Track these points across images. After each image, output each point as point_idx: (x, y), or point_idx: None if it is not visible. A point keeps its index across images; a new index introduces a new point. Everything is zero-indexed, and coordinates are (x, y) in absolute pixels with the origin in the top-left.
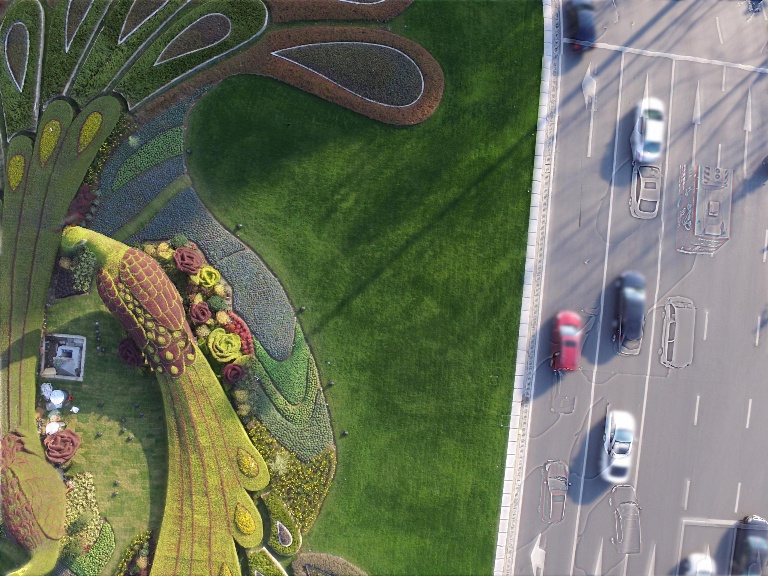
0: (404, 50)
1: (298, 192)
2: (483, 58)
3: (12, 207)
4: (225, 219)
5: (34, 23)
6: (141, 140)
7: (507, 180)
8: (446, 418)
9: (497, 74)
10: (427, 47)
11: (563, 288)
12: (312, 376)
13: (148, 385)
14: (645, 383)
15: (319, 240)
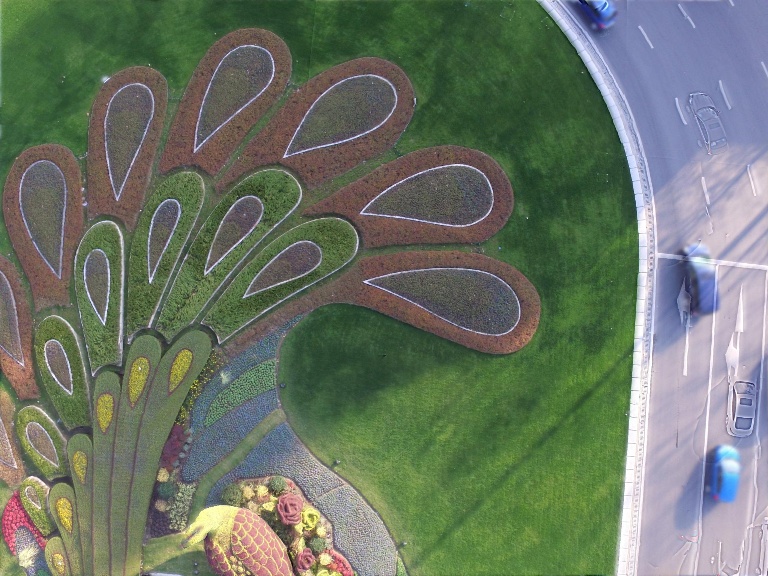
0: (500, 275)
1: (396, 426)
2: (579, 279)
3: (103, 449)
4: (322, 455)
5: (113, 250)
6: (233, 375)
7: (605, 405)
8: None
9: (593, 295)
10: (522, 269)
11: (661, 510)
12: None
13: None
14: None
15: (419, 474)
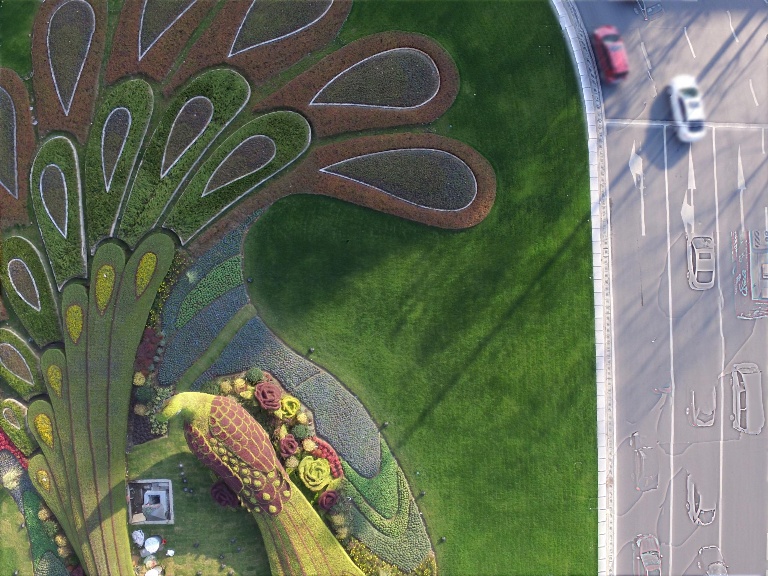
0: (453, 152)
1: (366, 308)
2: (531, 150)
3: (76, 360)
4: (296, 345)
5: (68, 164)
6: (199, 274)
7: (569, 270)
8: (537, 510)
9: (547, 164)
10: (475, 145)
11: (633, 368)
12: (403, 488)
13: (241, 519)
14: (719, 448)
15: (393, 354)
